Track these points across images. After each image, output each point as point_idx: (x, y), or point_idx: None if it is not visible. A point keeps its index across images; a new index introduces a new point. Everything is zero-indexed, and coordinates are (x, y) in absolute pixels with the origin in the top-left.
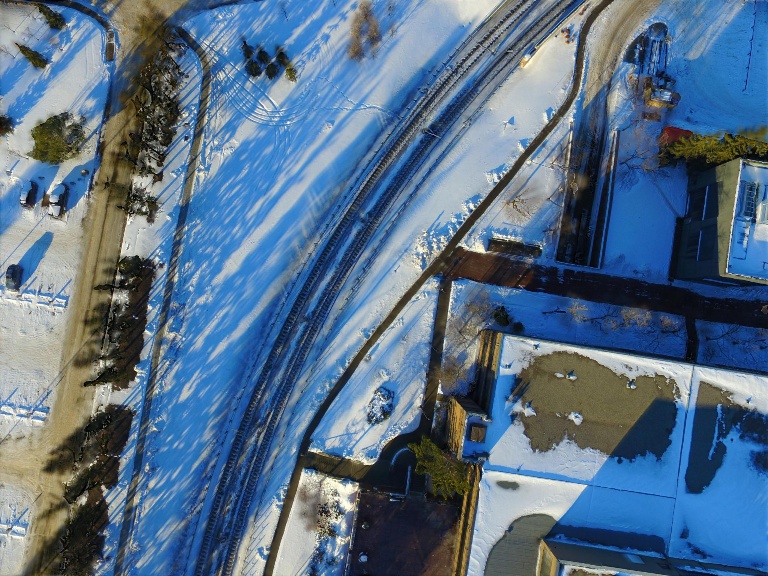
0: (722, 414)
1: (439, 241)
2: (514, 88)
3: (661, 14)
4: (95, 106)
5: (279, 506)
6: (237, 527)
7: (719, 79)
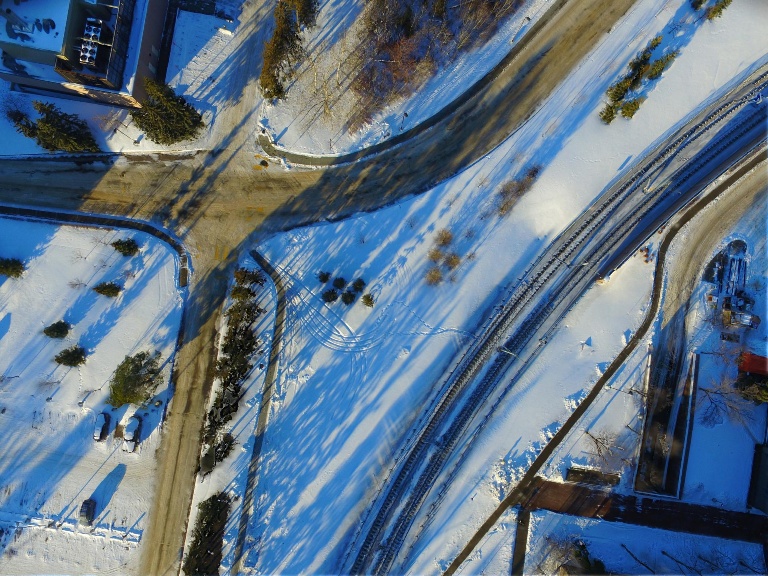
0: None
1: (517, 472)
2: (591, 305)
3: (740, 231)
4: (168, 334)
5: None
6: None
7: None
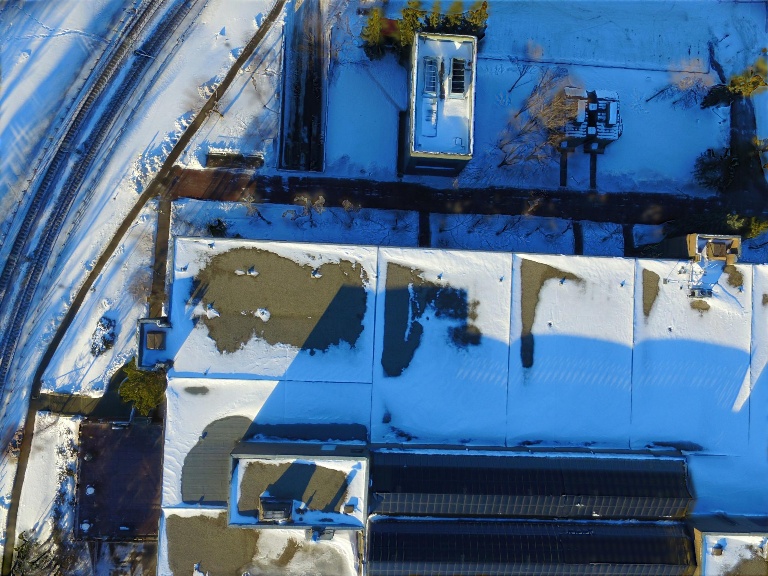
0: (414, 293)
1: (153, 162)
2: None
3: None
4: None
5: (15, 453)
6: None
7: None
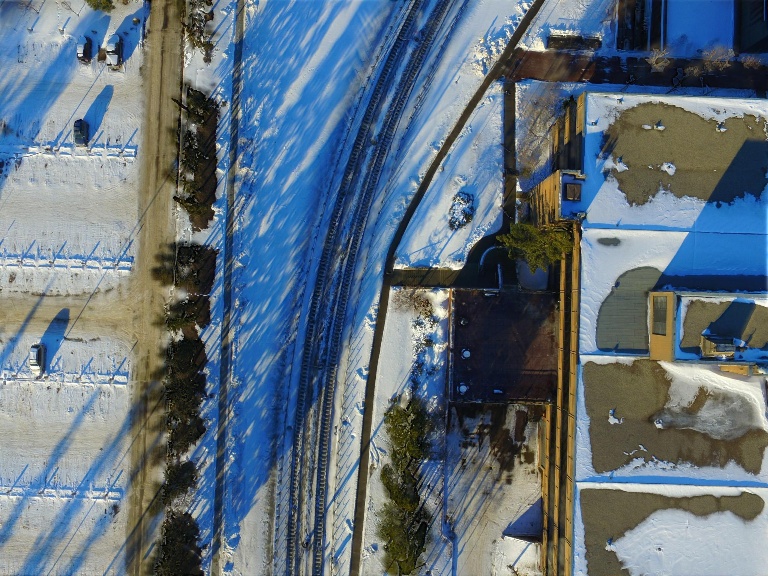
0: None
1: (497, 44)
2: None
3: None
4: None
5: (372, 326)
6: (333, 353)
7: None
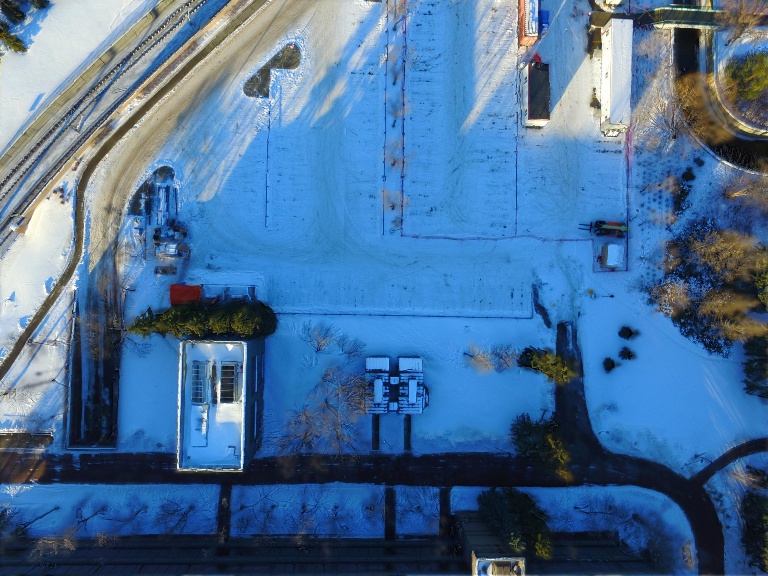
0: None
1: None
2: (16, 258)
3: (166, 156)
4: None
5: None
6: None
7: (239, 218)
